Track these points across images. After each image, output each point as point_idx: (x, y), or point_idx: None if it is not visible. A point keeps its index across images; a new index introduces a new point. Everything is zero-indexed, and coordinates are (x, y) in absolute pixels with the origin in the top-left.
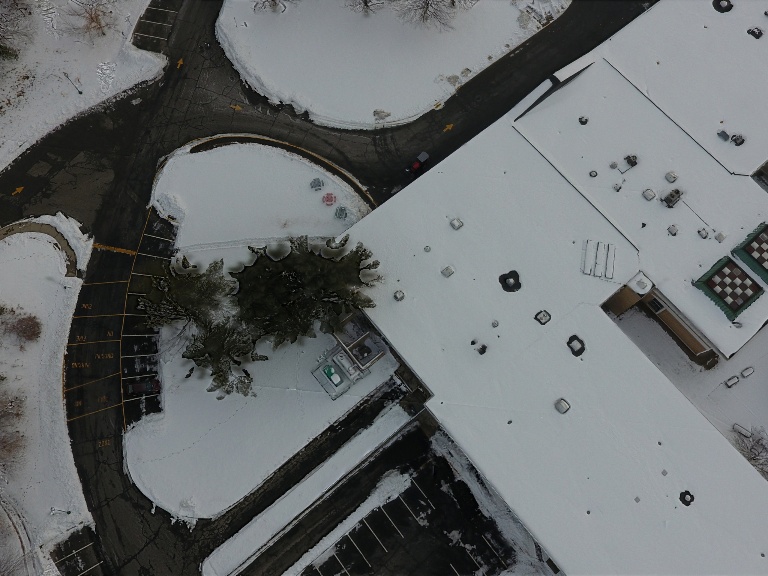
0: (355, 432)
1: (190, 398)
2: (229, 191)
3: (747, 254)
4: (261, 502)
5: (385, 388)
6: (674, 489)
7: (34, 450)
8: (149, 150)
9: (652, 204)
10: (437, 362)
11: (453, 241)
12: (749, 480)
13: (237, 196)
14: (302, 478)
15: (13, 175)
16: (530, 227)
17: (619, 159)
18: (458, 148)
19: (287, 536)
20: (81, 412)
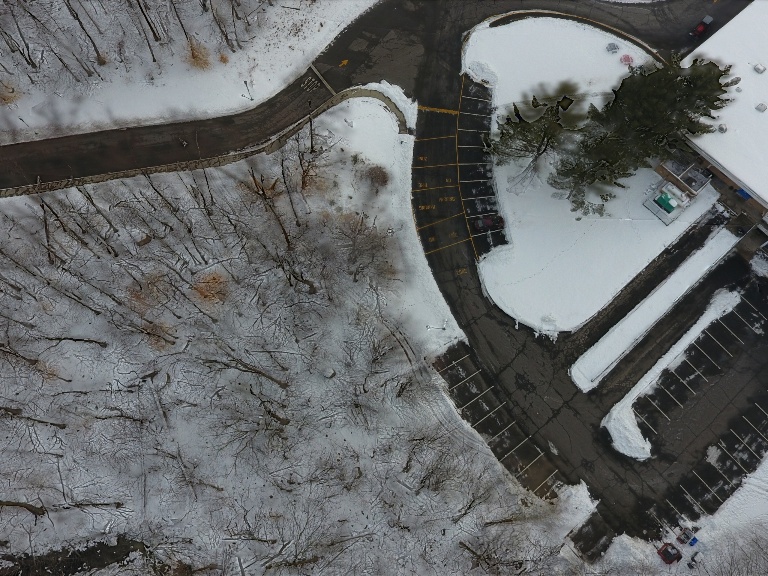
0: (689, 253)
1: (532, 231)
2: (533, 57)
3: None
4: (614, 316)
5: (709, 215)
6: None
7: (402, 278)
8: (452, 27)
9: None
10: None
11: (760, 83)
12: None
13: (541, 61)
14: (648, 294)
15: (337, 50)
16: None
17: None
18: (745, 7)
19: (640, 345)
20: (436, 246)
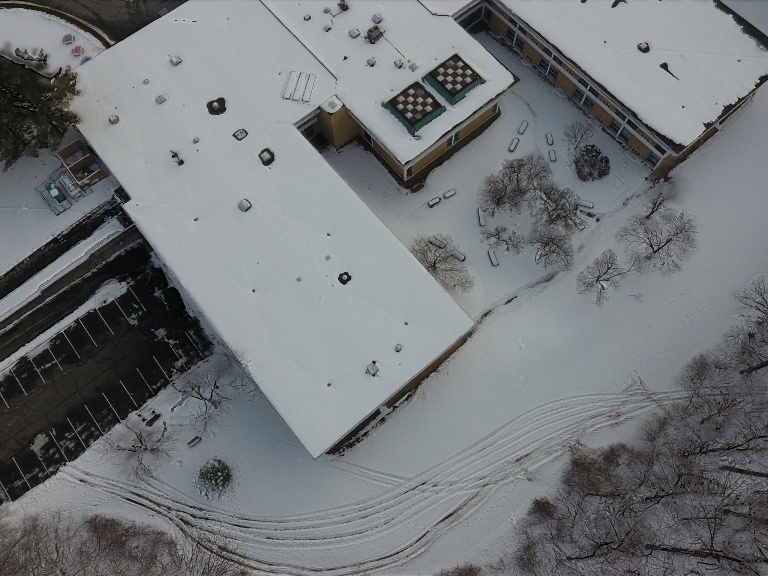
0: (75, 243)
1: None
2: None
3: (433, 78)
4: None
5: (107, 206)
6: (334, 271)
7: None
8: None
9: (356, 41)
10: (139, 172)
11: (170, 75)
12: (404, 263)
13: None
14: (23, 282)
15: None
16: (242, 62)
17: (333, 5)
18: None
19: (8, 333)
20: None
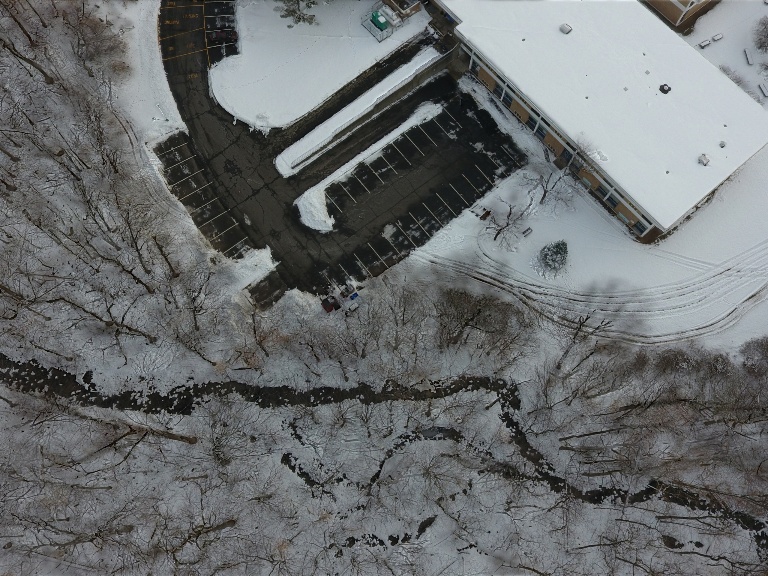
0: (397, 67)
1: (262, 45)
2: None
3: None
4: (322, 116)
5: (421, 37)
6: (655, 83)
7: (137, 78)
8: None
9: None
10: (464, 0)
11: None
12: (715, 77)
13: None
14: (355, 99)
15: None
16: None
17: None
18: None
19: (343, 143)
20: (174, 54)
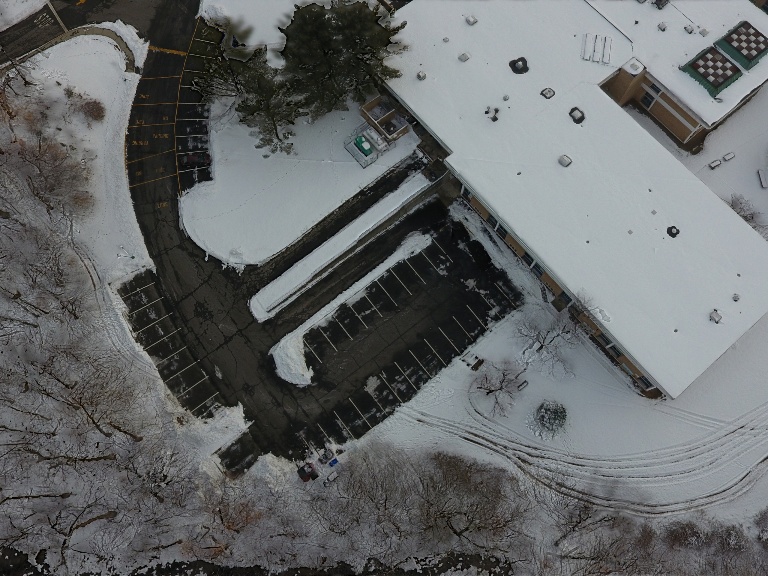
0: (383, 195)
1: (237, 169)
2: (269, 3)
3: (727, 43)
4: (301, 251)
5: (409, 161)
6: (662, 224)
7: (101, 208)
8: None
9: (644, 6)
10: (455, 127)
11: (469, 34)
12: (727, 218)
13: (276, 7)
14: (337, 232)
15: None
16: (536, 23)
17: None
18: None
19: (324, 281)
20: (141, 180)
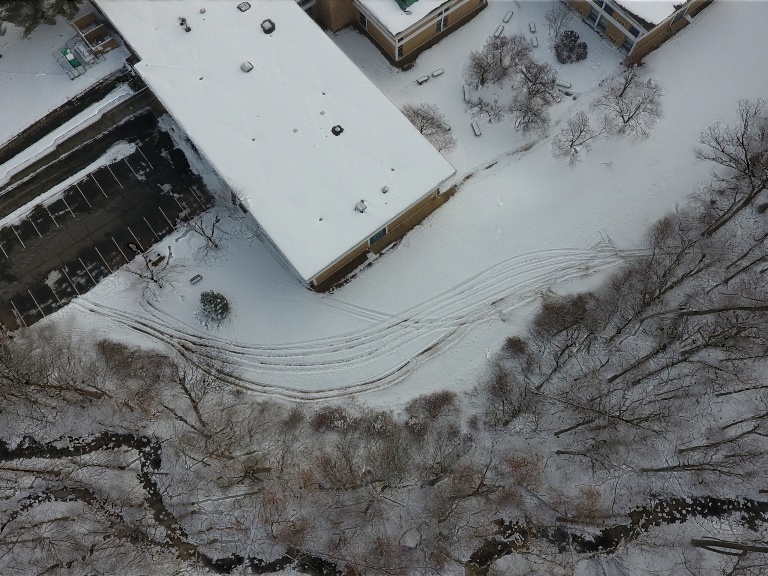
0: (88, 105)
1: None
2: None
3: None
4: (4, 156)
5: (118, 74)
6: (328, 124)
7: None
8: None
9: None
10: (149, 37)
11: None
12: (393, 118)
13: None
14: (40, 139)
15: None
16: None
17: None
18: None
19: (25, 184)
20: None
